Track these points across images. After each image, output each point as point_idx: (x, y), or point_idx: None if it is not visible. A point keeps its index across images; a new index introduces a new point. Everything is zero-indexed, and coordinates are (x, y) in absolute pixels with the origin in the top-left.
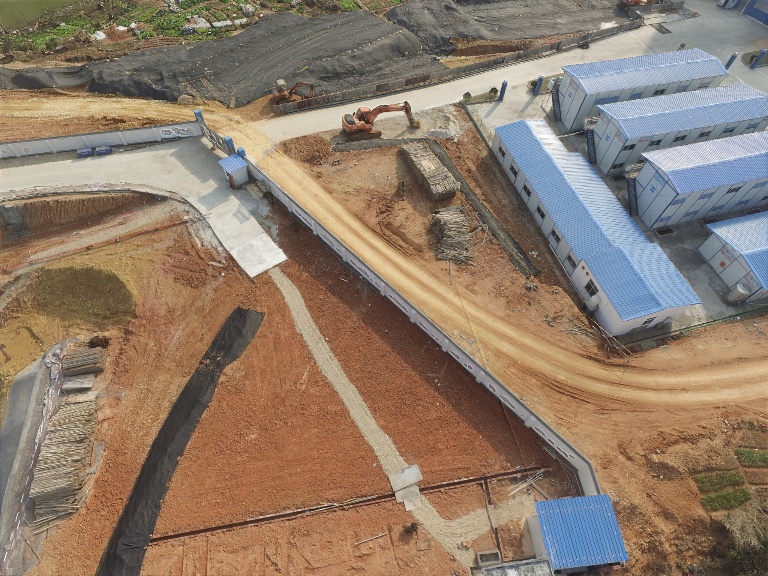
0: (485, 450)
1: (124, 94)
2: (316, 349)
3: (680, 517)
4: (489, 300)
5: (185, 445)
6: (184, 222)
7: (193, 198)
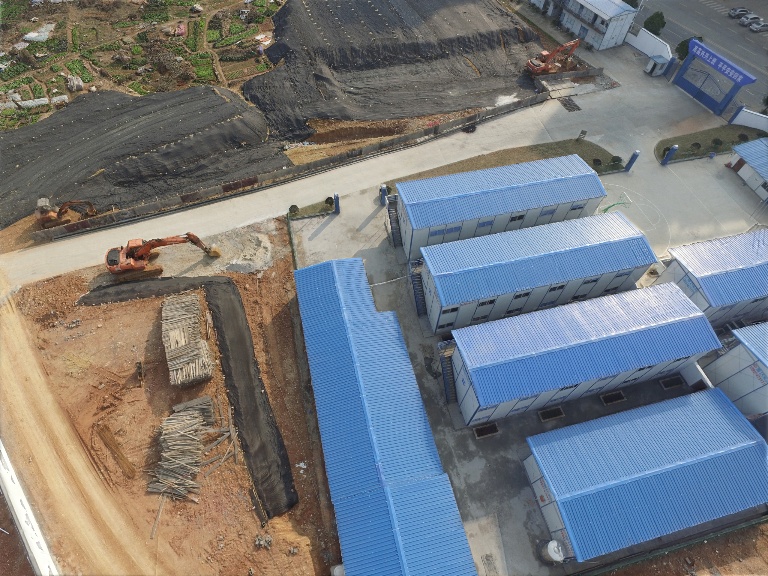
0: None
1: None
2: None
3: None
4: (195, 567)
5: None
6: None
7: None
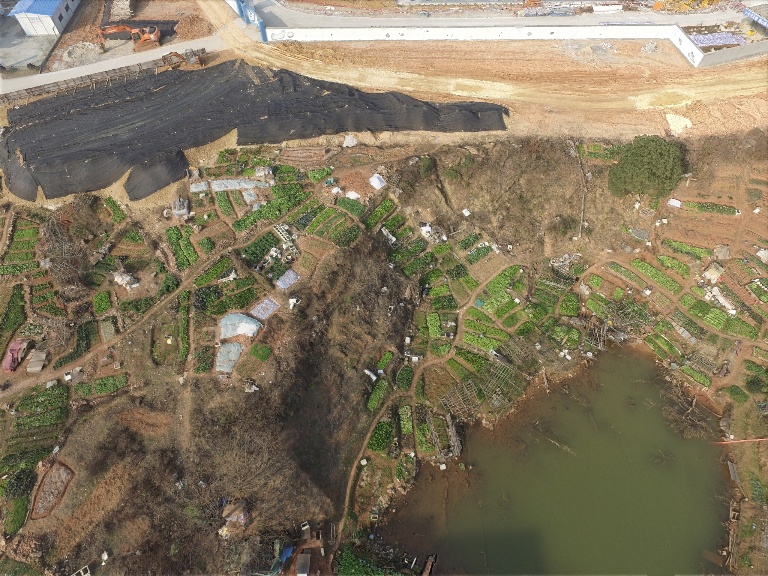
0: None
1: None
2: None
3: None
4: None
5: None
6: None
7: (278, 5)
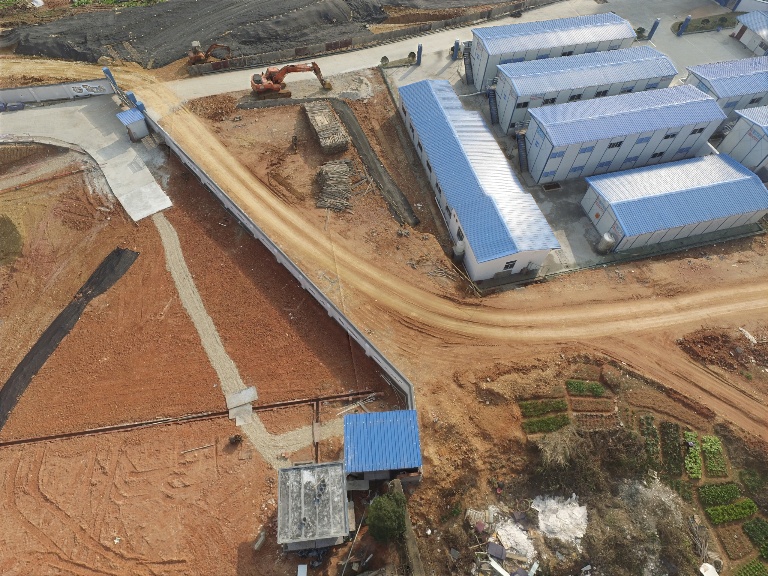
0: (323, 375)
1: (48, 56)
2: (181, 285)
3: (496, 437)
4: (359, 245)
5: (41, 365)
6: (80, 171)
7: (93, 150)
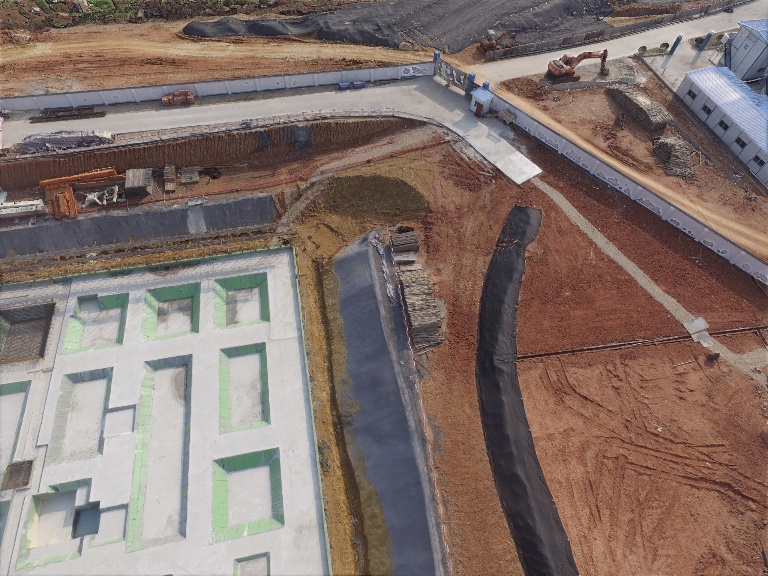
0: (752, 310)
1: (350, 41)
2: (593, 236)
3: None
4: (719, 207)
5: (517, 298)
6: (447, 141)
7: (448, 123)
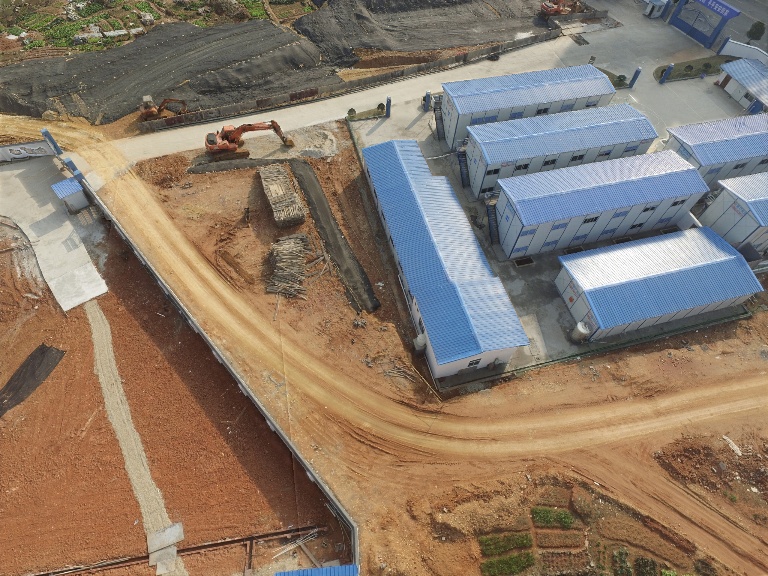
0: (260, 507)
1: None
2: (109, 392)
3: None
4: (311, 338)
5: None
6: (10, 250)
7: (25, 224)
